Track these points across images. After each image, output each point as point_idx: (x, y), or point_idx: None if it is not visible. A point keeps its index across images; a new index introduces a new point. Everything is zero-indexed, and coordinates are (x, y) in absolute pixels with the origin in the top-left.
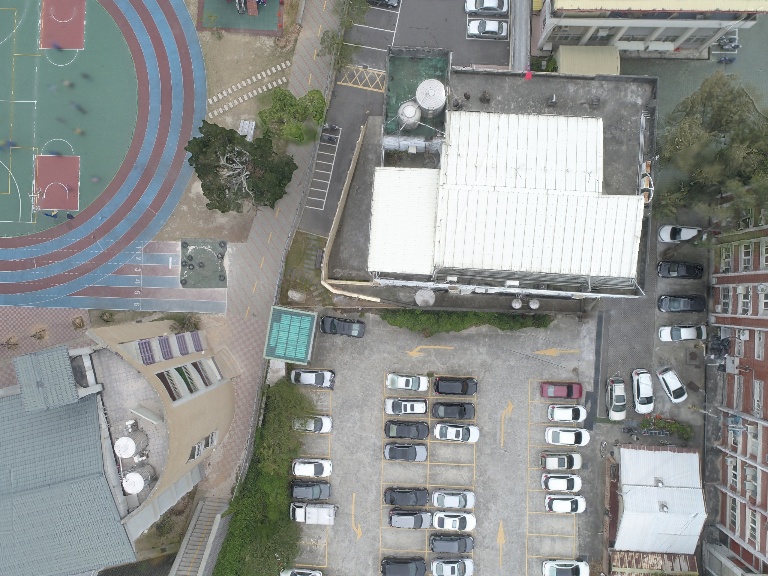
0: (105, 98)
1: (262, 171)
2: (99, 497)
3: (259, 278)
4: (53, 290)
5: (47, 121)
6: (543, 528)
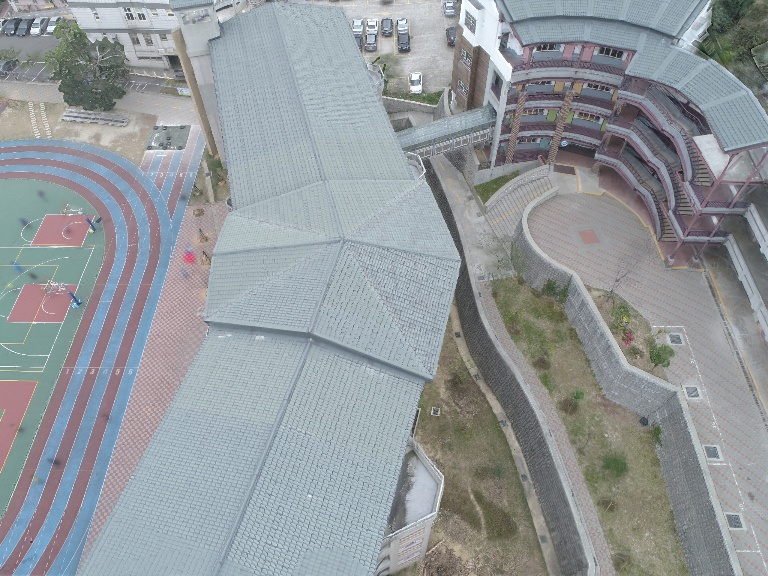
0: (2, 199)
1: (100, 53)
2: (291, 8)
3: (188, 109)
4: (163, 230)
5: (2, 238)
6: (377, 0)
